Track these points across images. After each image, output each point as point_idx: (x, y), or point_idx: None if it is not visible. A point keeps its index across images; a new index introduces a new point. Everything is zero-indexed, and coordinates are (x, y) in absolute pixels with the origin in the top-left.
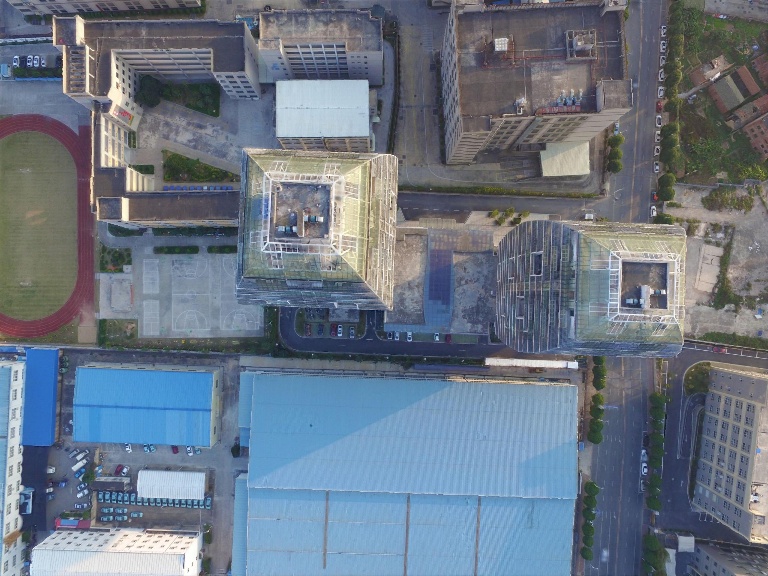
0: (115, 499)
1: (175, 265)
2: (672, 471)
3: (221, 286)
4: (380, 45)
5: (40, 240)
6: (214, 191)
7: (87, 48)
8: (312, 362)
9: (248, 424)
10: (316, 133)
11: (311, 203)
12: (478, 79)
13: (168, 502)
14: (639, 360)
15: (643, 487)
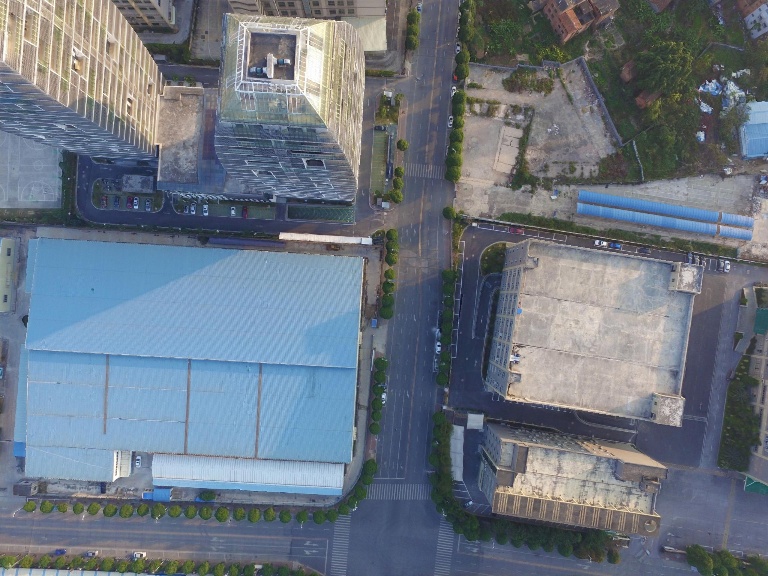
0: None
1: None
2: (466, 351)
3: (20, 157)
4: None
5: None
6: None
7: None
8: (109, 235)
9: None
10: None
11: None
12: None
13: None
14: (437, 240)
15: (436, 365)
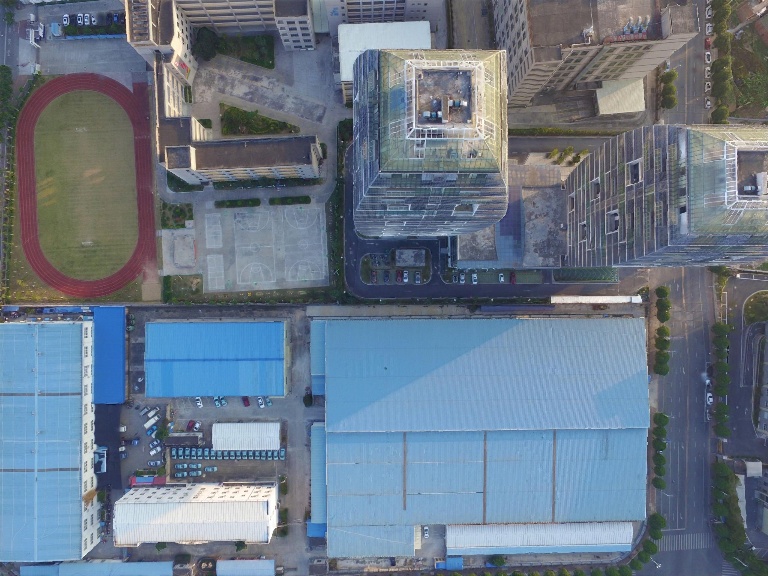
0: (188, 455)
1: (237, 218)
2: (736, 399)
3: (284, 237)
4: None
5: (99, 199)
6: (281, 137)
7: None
8: (379, 309)
9: (321, 371)
10: None
11: (452, 90)
12: (545, 11)
13: (242, 455)
14: (699, 293)
15: (709, 416)
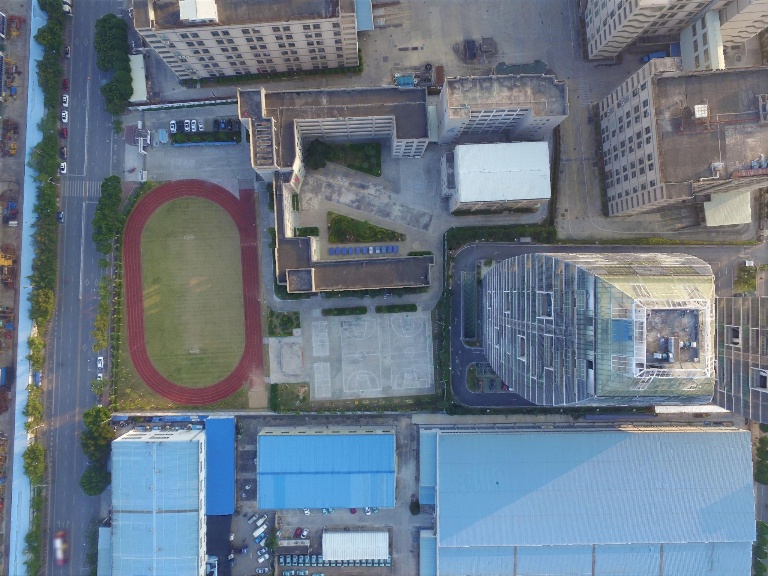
0: (296, 562)
1: (344, 326)
2: None
3: (391, 345)
4: (565, 109)
5: (206, 307)
6: (399, 257)
7: (273, 120)
8: (484, 417)
9: (431, 483)
10: (499, 196)
11: (679, 328)
12: (674, 144)
13: (349, 562)
14: None
15: None
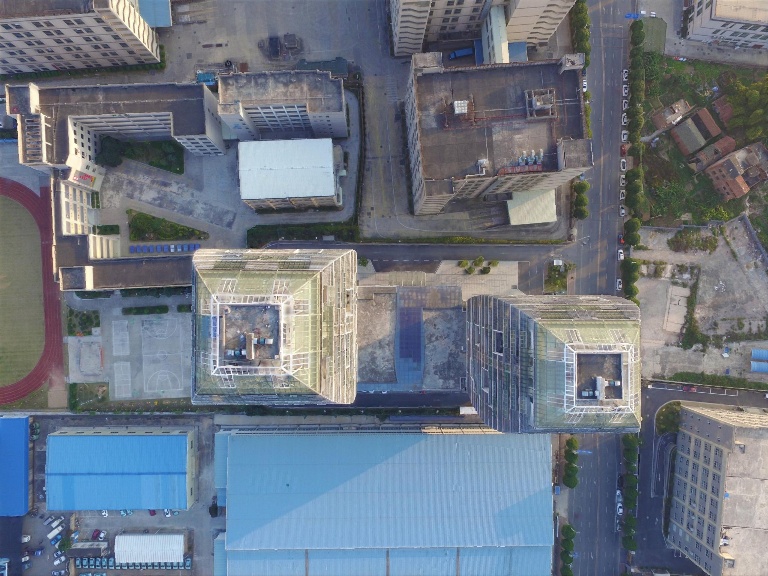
0: (93, 564)
1: (145, 326)
2: (647, 510)
3: None
4: (341, 105)
5: (5, 305)
6: (180, 255)
7: (42, 116)
8: (287, 418)
9: (224, 485)
10: (281, 194)
11: (260, 324)
12: (440, 141)
13: (147, 565)
14: None
15: (619, 527)
